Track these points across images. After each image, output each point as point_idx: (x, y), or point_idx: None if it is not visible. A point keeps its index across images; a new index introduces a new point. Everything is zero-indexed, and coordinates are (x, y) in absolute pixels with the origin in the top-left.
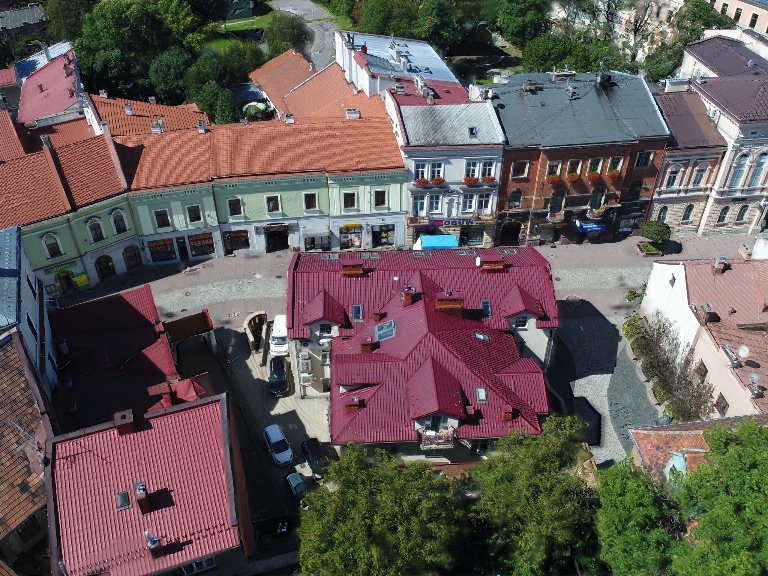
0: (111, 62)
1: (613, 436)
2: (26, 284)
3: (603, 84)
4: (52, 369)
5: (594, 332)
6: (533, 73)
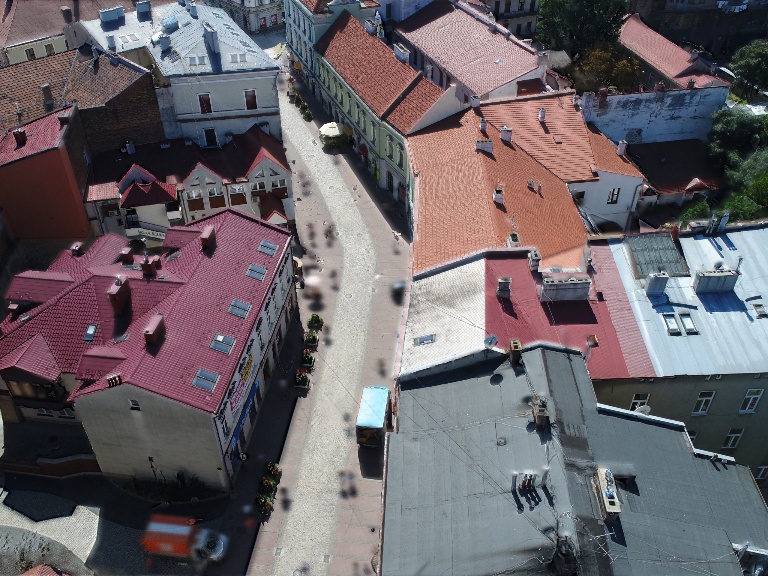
0: (729, 117)
1: (4, 520)
2: (240, 91)
3: (556, 555)
4: (204, 135)
5: (167, 575)
6: (767, 528)
